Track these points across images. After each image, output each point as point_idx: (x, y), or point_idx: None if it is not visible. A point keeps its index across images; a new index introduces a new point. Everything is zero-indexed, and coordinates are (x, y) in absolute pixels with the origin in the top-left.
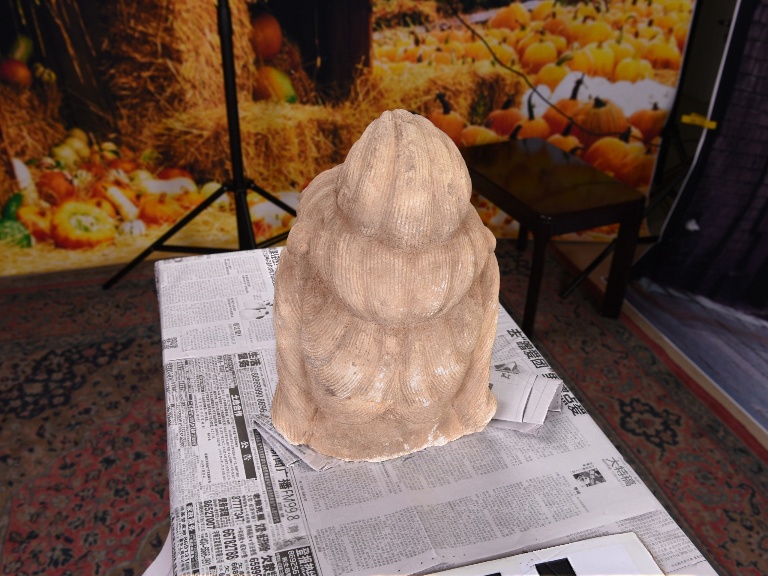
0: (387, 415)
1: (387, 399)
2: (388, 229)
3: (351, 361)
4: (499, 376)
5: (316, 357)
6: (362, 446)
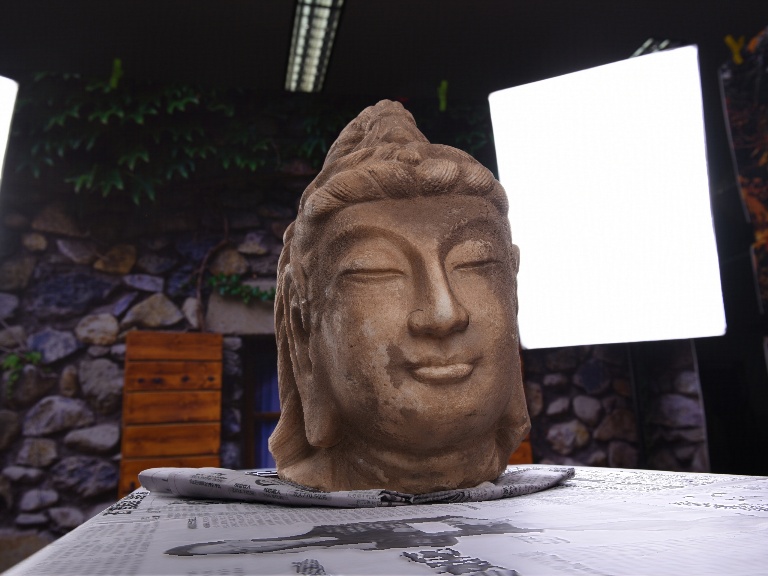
0: None
1: None
2: None
3: None
4: (231, 474)
5: None
6: None
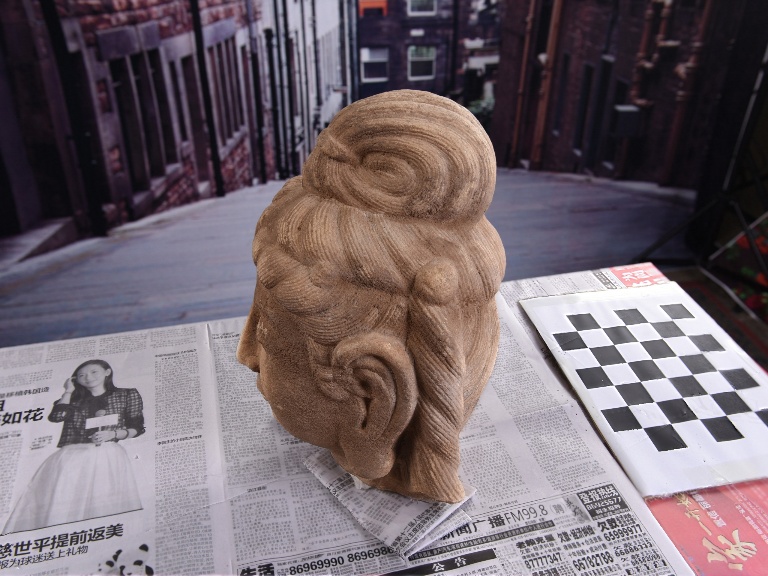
0: None
1: None
2: None
3: None
4: None
5: None
6: None
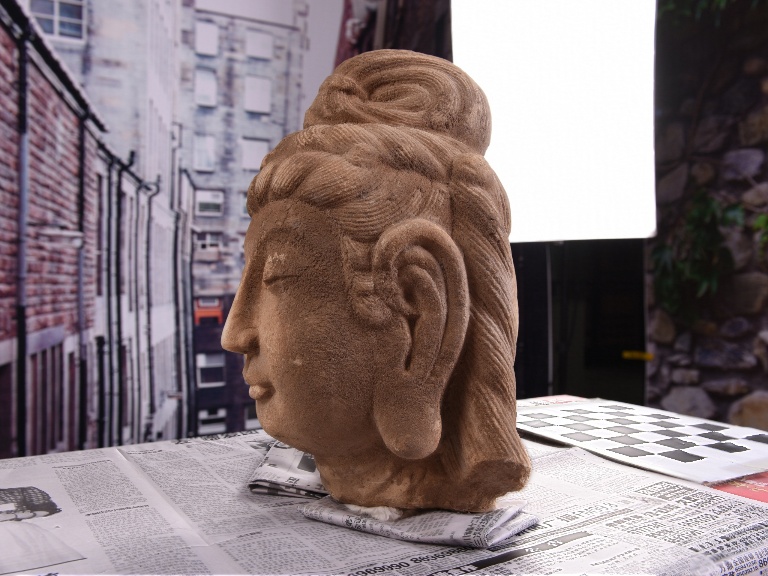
0: None
1: None
2: None
3: None
4: None
5: None
6: None
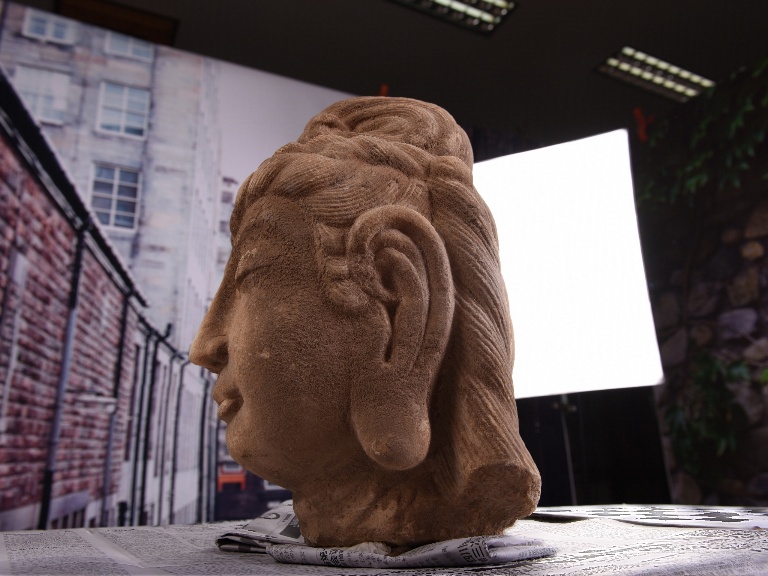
0: None
1: None
2: None
3: None
4: (291, 506)
5: None
6: None
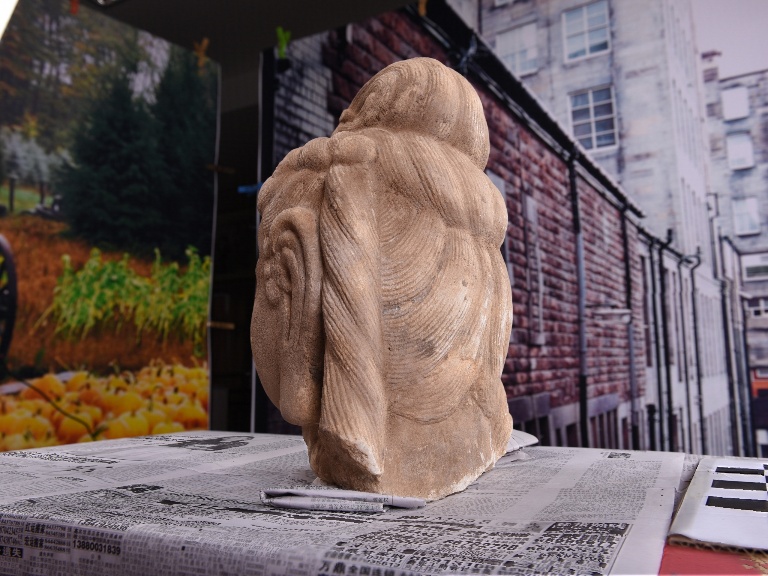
0: (467, 398)
1: (480, 355)
2: (464, 126)
3: (461, 279)
4: None
5: (408, 293)
6: (447, 460)
